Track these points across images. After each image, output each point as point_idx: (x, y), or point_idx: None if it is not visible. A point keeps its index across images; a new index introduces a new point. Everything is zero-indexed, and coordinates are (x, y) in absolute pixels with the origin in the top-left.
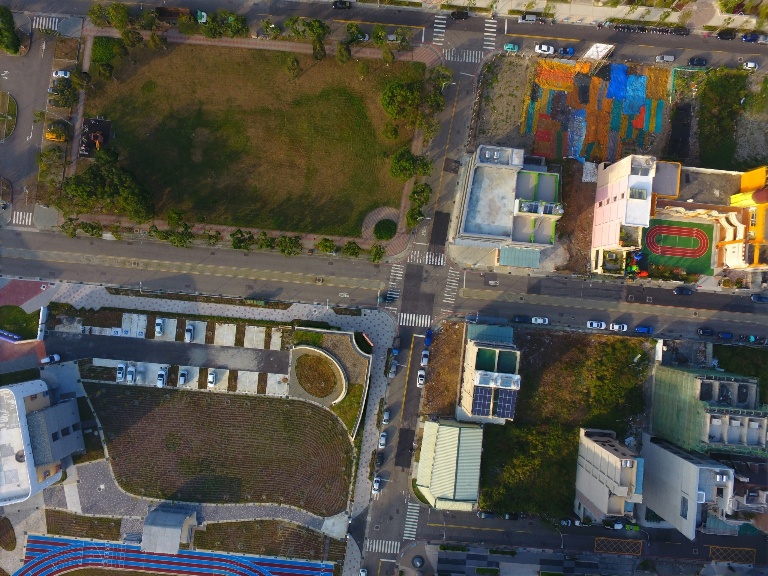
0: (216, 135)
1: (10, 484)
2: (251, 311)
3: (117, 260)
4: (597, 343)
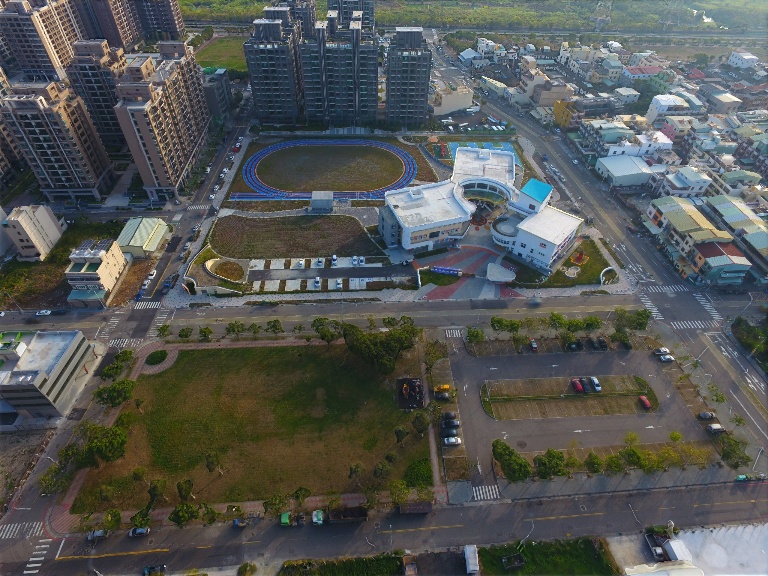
0: (304, 413)
1: (399, 198)
2: (274, 298)
3: (376, 317)
4: (2, 306)
